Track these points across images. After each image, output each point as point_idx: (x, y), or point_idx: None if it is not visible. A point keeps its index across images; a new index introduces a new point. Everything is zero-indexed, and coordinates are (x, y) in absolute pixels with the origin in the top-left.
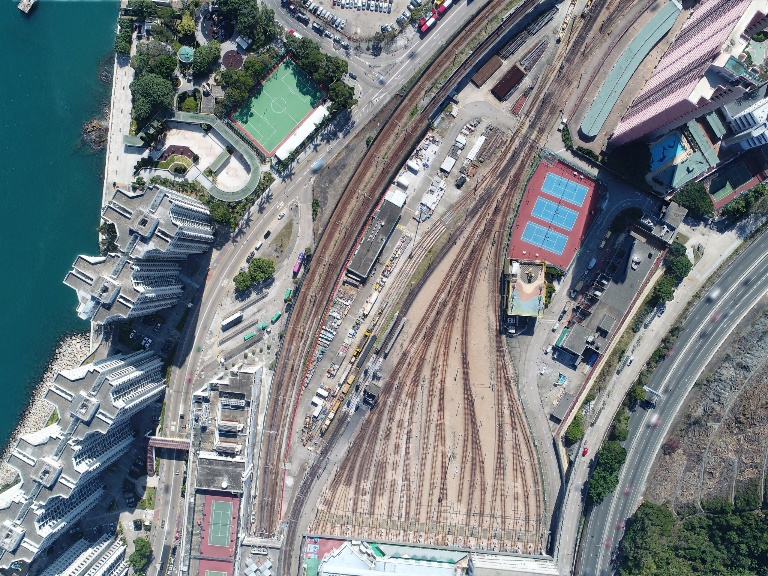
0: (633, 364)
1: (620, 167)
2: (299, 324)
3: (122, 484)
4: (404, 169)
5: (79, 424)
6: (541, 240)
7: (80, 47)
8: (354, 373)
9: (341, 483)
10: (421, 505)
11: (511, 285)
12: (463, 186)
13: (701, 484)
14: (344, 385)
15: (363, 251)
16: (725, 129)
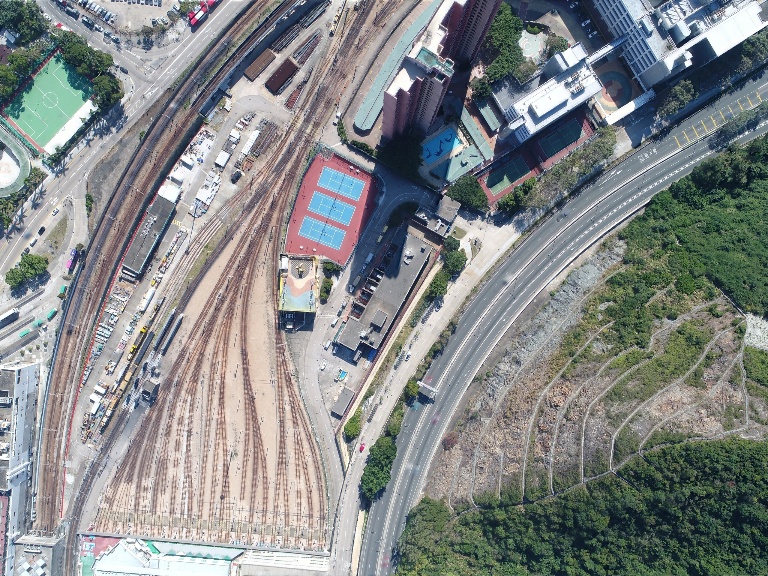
0: (411, 359)
1: (387, 161)
2: (76, 321)
3: None
4: (178, 164)
5: None
6: (318, 235)
7: None
8: (131, 370)
9: (122, 480)
10: (203, 502)
11: (282, 280)
12: (239, 181)
13: (473, 479)
14: (123, 382)
15: (136, 247)
16: (501, 122)
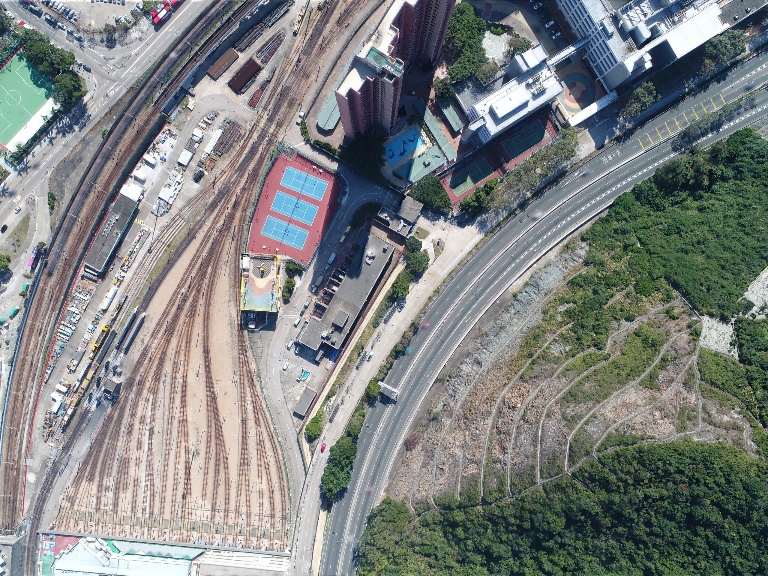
0: (373, 359)
1: (349, 161)
2: (38, 319)
3: None
4: (141, 163)
5: None
6: (281, 234)
7: None
8: (93, 368)
9: (84, 479)
10: (165, 501)
11: (243, 280)
12: (201, 180)
13: (434, 480)
14: (85, 381)
15: (98, 245)
16: (465, 123)
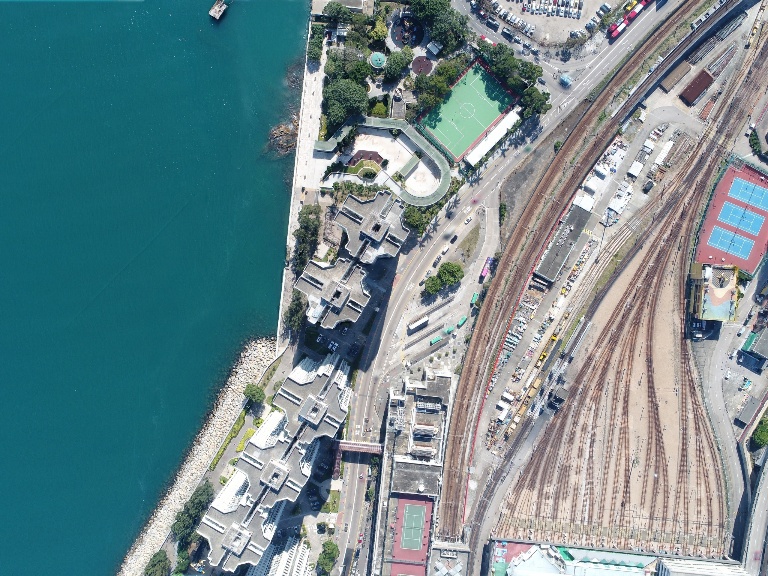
0: None
1: None
2: (485, 328)
3: (306, 487)
4: (591, 174)
5: (306, 428)
6: (727, 245)
7: (269, 53)
8: (540, 377)
9: (524, 487)
10: (604, 509)
11: (703, 290)
12: (650, 191)
13: None
14: (529, 389)
15: (552, 256)
16: None
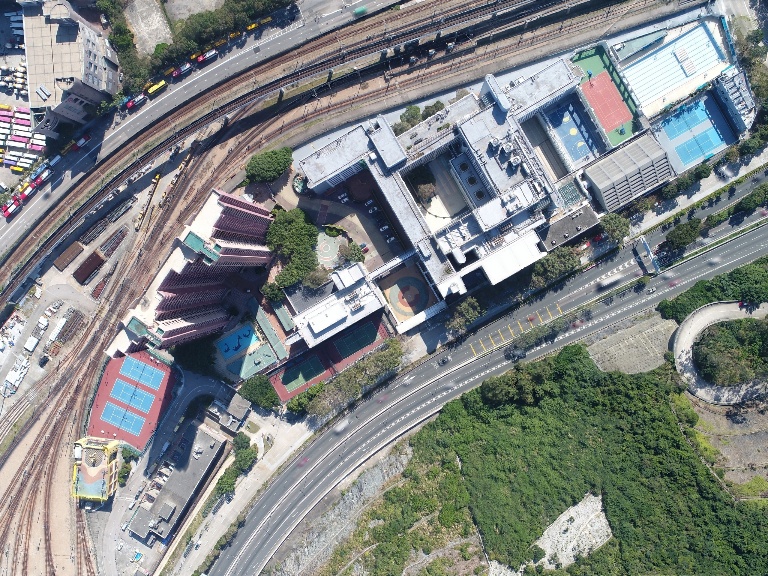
0: (201, 548)
1: (177, 361)
2: None
3: None
4: None
5: None
6: (119, 420)
7: None
8: None
9: None
10: None
11: (76, 468)
12: (46, 365)
13: None
14: None
15: None
16: None
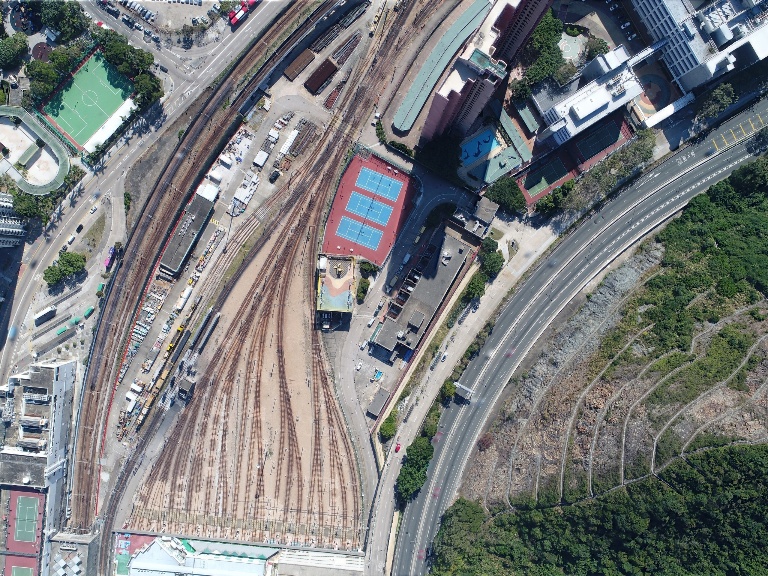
0: (447, 360)
1: (427, 162)
2: (113, 319)
3: None
4: (217, 163)
5: None
6: (356, 235)
7: None
8: (168, 368)
9: (157, 479)
10: (238, 501)
11: (320, 280)
12: (277, 180)
13: (509, 480)
14: (159, 380)
15: (174, 245)
16: (540, 124)
